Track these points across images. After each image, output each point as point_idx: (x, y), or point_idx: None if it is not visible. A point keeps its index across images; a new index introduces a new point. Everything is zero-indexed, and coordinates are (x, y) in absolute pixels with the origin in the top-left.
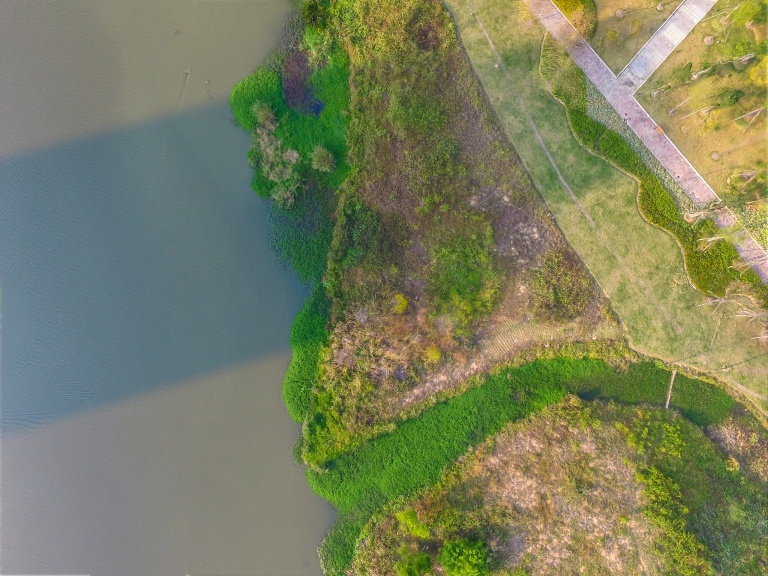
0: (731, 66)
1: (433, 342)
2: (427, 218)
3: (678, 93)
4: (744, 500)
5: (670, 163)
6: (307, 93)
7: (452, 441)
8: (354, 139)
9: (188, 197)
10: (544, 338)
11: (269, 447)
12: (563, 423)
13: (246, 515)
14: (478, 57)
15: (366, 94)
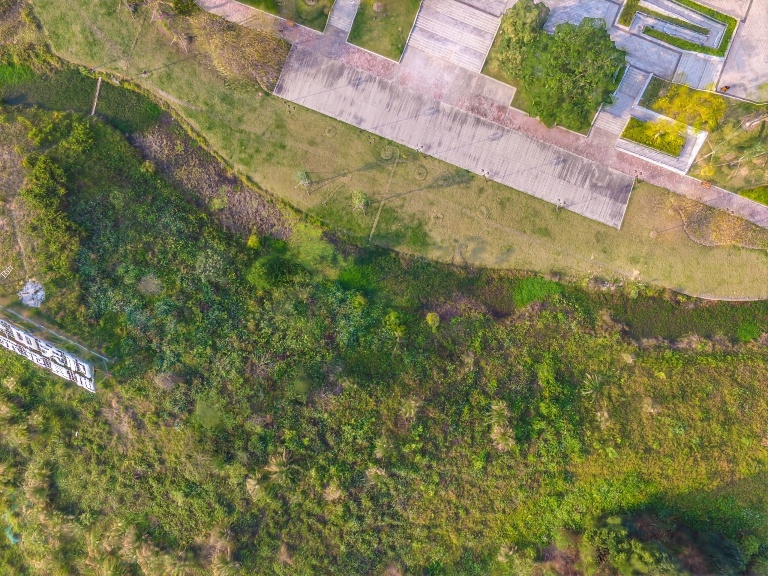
0: None
1: None
2: None
3: None
4: (149, 197)
5: None
6: None
7: None
8: None
9: None
10: None
11: None
12: None
13: None
14: None
15: None
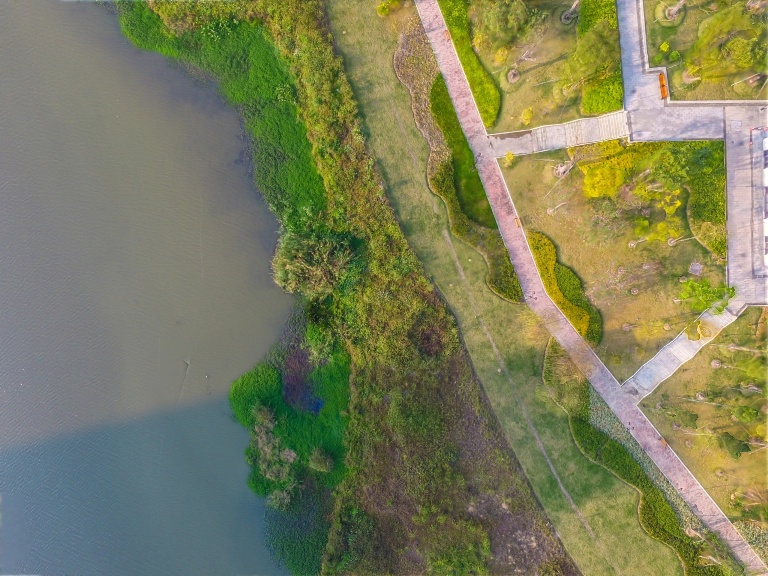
0: (738, 391)
1: None
2: (424, 524)
3: None
4: None
5: (673, 474)
6: (307, 390)
7: None
8: (353, 442)
9: (184, 490)
10: None
11: None
12: None
13: None
14: (481, 360)
15: (366, 395)
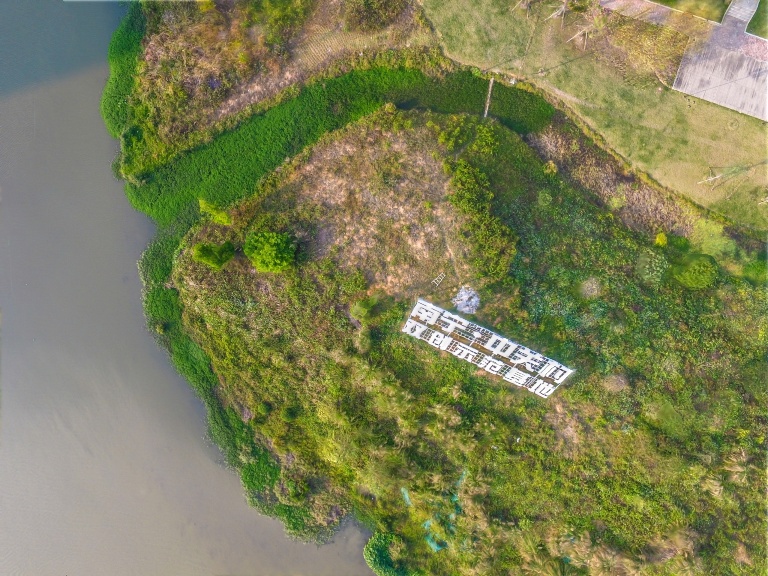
0: None
1: (244, 49)
2: None
3: None
4: (560, 198)
5: None
6: None
7: (269, 153)
8: None
9: None
10: (358, 46)
11: (88, 162)
12: (377, 129)
13: (67, 231)
14: None
15: None
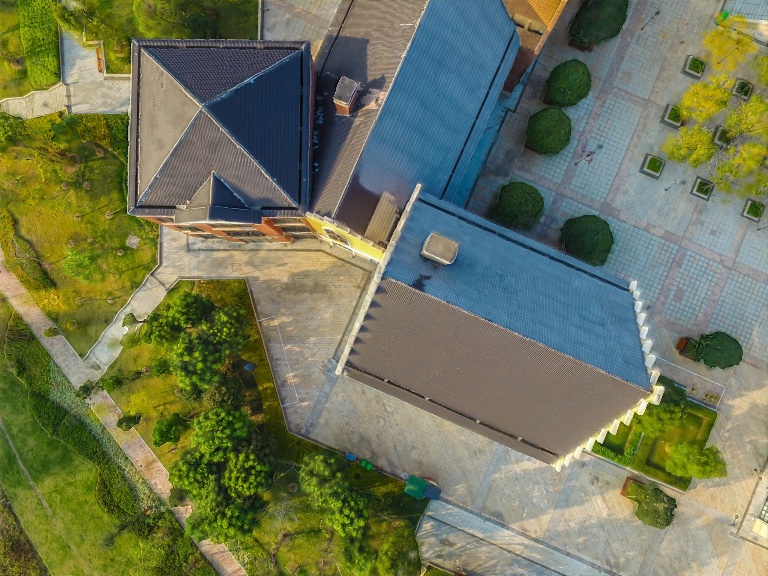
0: None
1: None
2: None
3: (136, 384)
4: None
5: (133, 451)
6: None
7: None
8: None
9: None
10: None
11: None
12: None
13: None
14: None
15: None
